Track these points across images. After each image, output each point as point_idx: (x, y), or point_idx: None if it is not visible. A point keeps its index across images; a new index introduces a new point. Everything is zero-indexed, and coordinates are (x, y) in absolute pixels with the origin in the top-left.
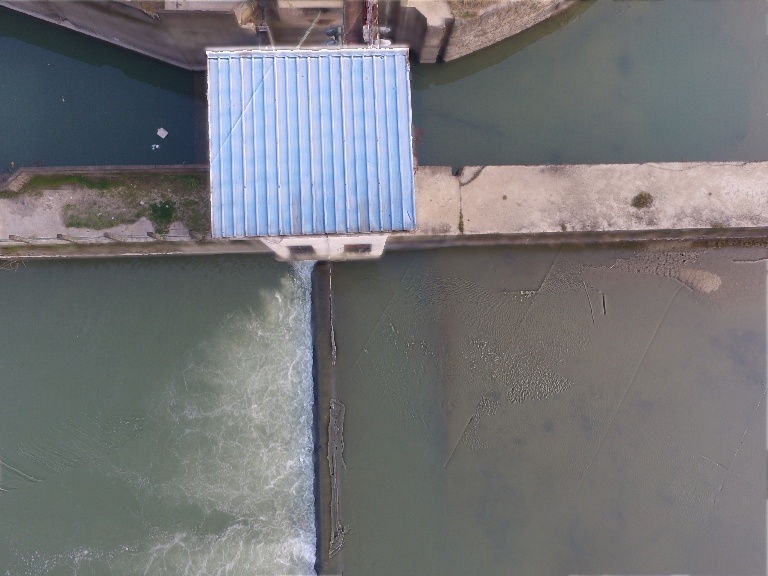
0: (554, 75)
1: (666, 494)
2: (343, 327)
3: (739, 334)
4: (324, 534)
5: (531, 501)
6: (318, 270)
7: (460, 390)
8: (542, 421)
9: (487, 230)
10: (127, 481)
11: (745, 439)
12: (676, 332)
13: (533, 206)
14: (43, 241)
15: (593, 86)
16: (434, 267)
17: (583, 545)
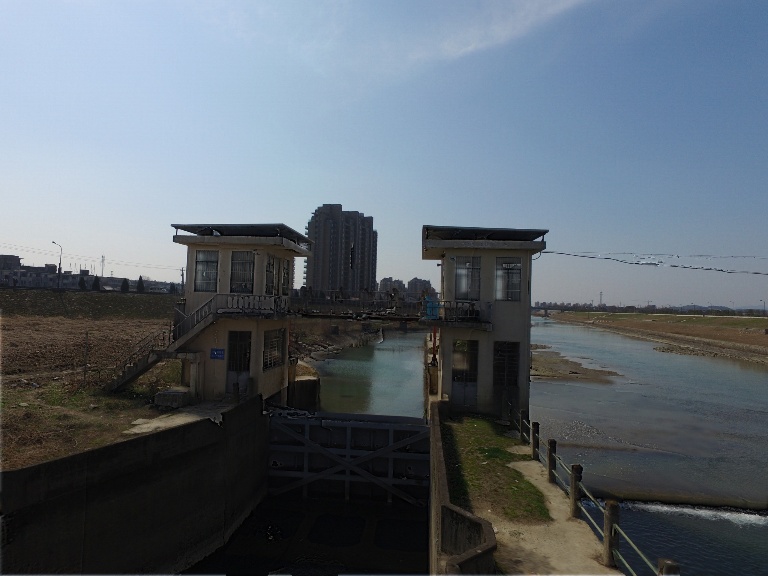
0: None
1: None
2: (586, 482)
3: None
4: None
5: None
6: None
7: None
8: (612, 428)
9: None
10: None
11: None
12: None
13: None
14: (599, 549)
15: None
16: None
17: None
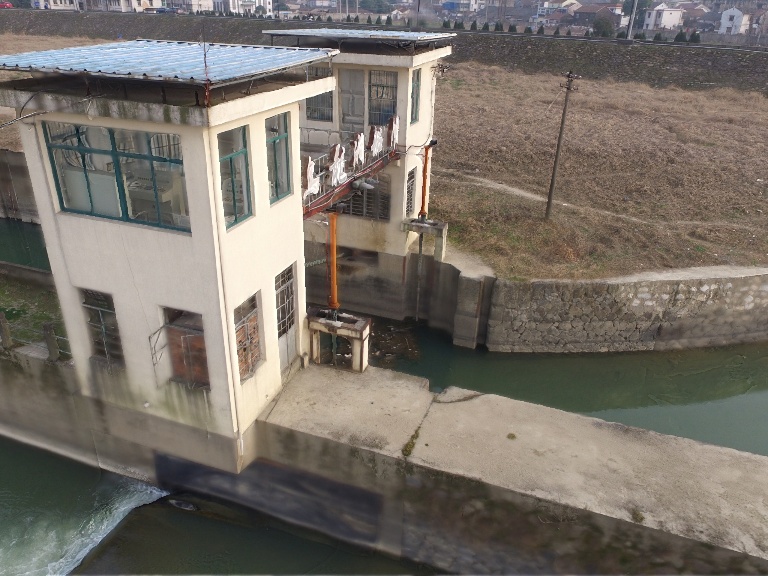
0: (663, 408)
1: None
2: None
3: None
4: None
5: None
6: (138, 512)
7: None
8: None
9: (458, 469)
10: None
11: None
12: None
13: (568, 463)
14: None
15: (736, 434)
16: None
17: None
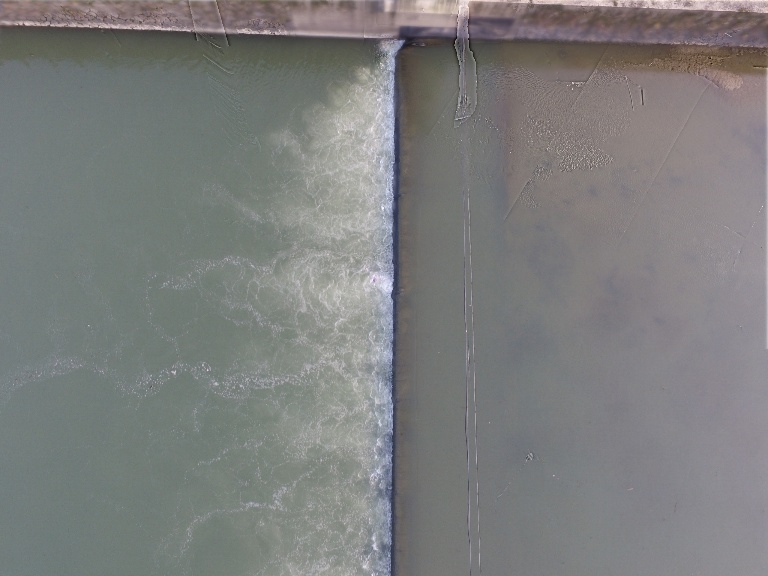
0: None
1: (692, 254)
2: (421, 102)
3: (757, 128)
4: (401, 266)
5: (577, 253)
6: (402, 54)
7: (519, 158)
8: (588, 188)
9: (552, 1)
10: (233, 222)
11: (761, 214)
12: (703, 124)
13: None
14: None
15: None
16: (499, 58)
17: (621, 291)
